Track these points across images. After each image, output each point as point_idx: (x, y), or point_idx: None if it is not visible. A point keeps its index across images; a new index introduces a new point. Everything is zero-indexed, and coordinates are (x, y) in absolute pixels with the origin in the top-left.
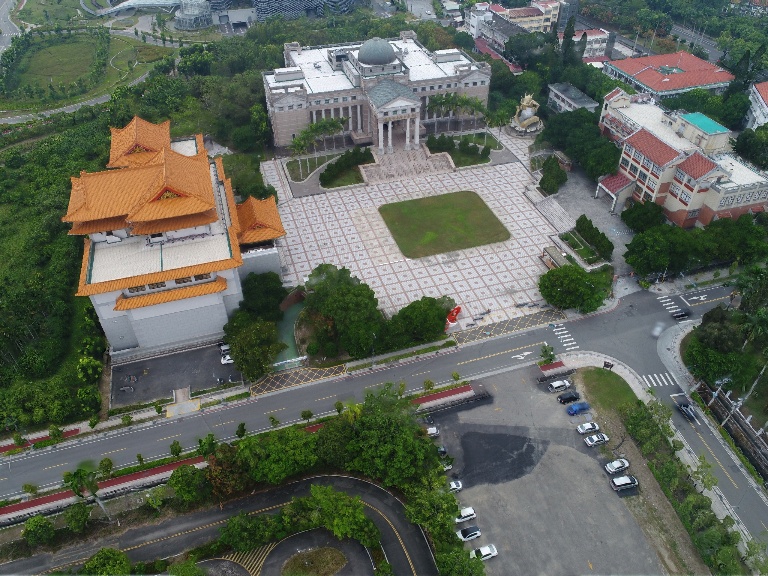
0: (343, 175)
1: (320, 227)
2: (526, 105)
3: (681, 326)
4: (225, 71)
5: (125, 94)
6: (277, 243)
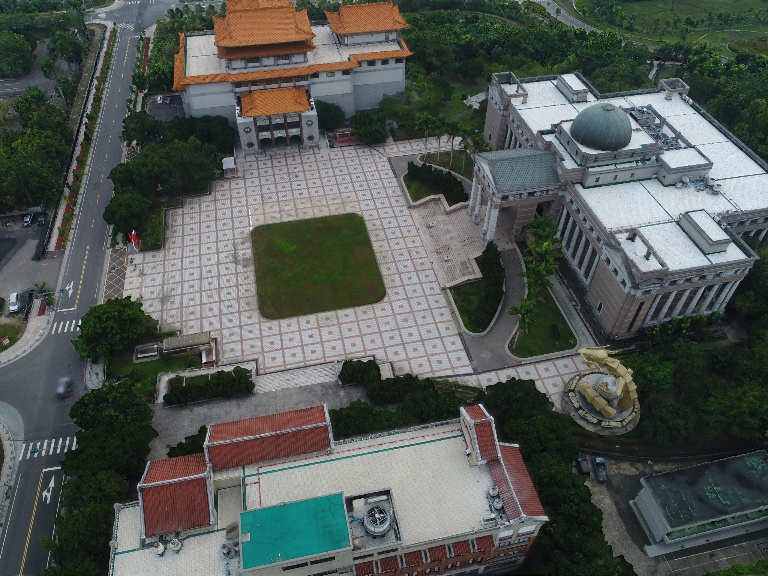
0: (428, 186)
1: (327, 173)
2: (582, 355)
3: (18, 443)
4: (694, 88)
5: (580, 34)
6: (303, 148)
